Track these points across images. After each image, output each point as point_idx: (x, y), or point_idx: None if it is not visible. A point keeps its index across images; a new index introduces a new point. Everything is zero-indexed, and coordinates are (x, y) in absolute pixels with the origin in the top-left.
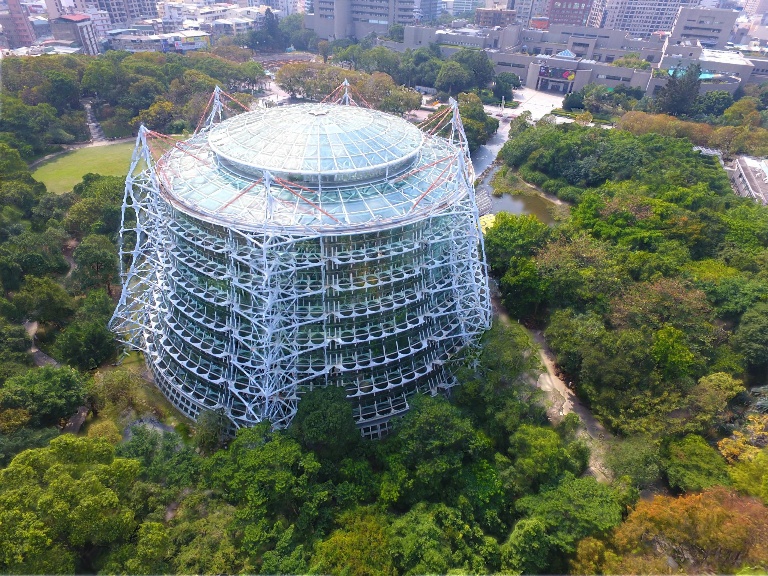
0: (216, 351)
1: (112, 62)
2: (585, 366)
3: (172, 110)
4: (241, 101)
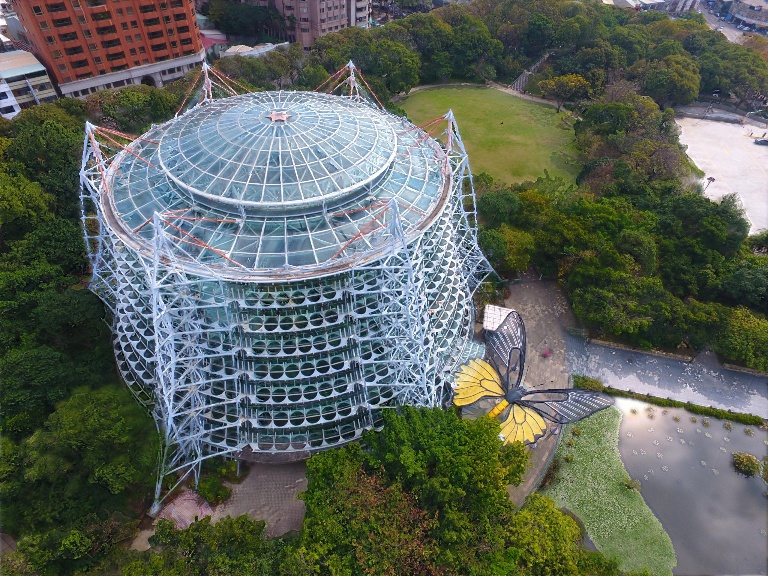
0: None
1: (593, 21)
2: (128, 551)
3: (576, 87)
4: (626, 107)
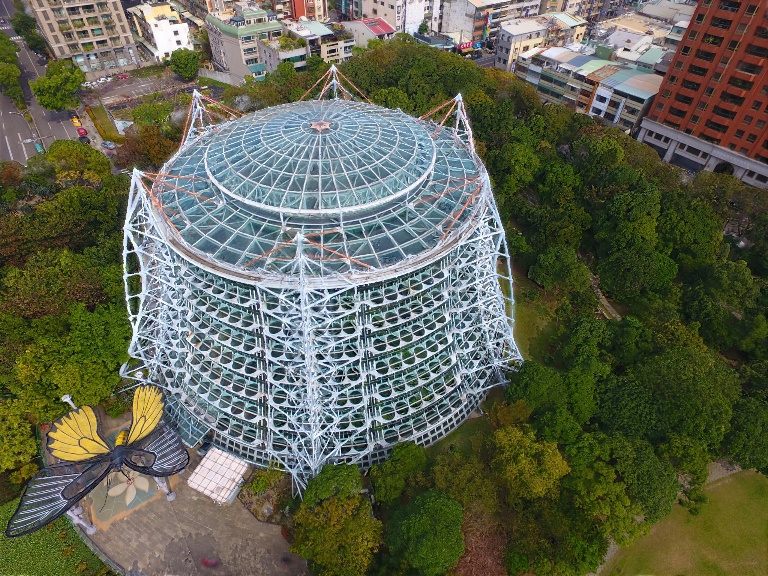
0: None
1: None
2: None
3: None
4: None
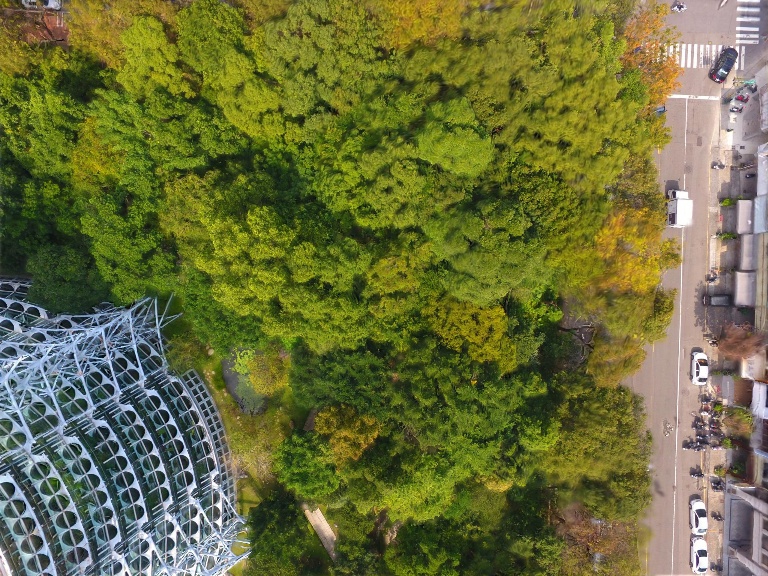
0: (132, 417)
1: None
2: None
3: None
4: None
